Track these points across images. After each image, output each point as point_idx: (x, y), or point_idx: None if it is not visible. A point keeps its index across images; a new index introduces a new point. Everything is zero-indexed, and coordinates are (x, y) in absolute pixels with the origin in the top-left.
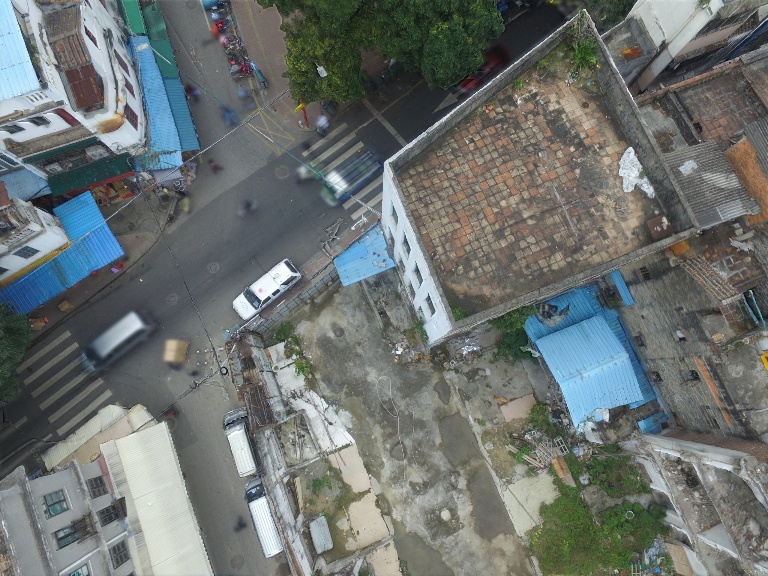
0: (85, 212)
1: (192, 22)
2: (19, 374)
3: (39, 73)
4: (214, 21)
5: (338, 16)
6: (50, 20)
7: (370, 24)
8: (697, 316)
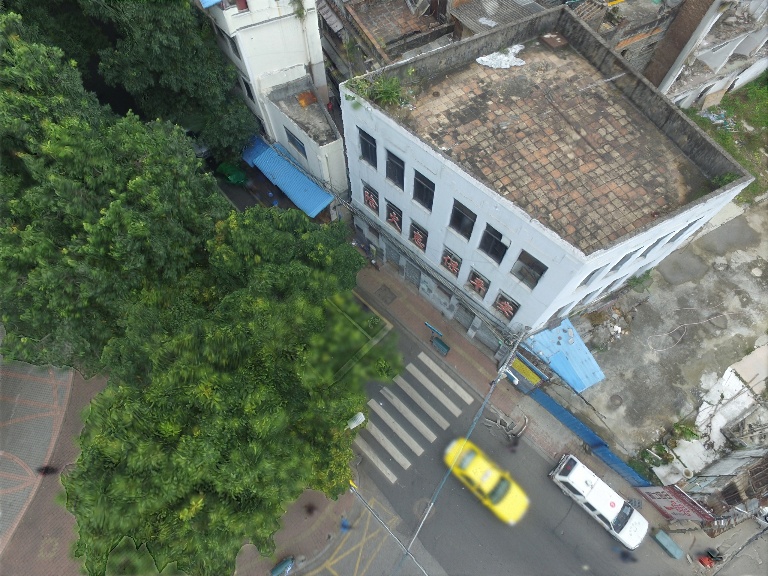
0: None
1: None
2: None
3: None
4: None
5: None
6: None
7: None
8: None
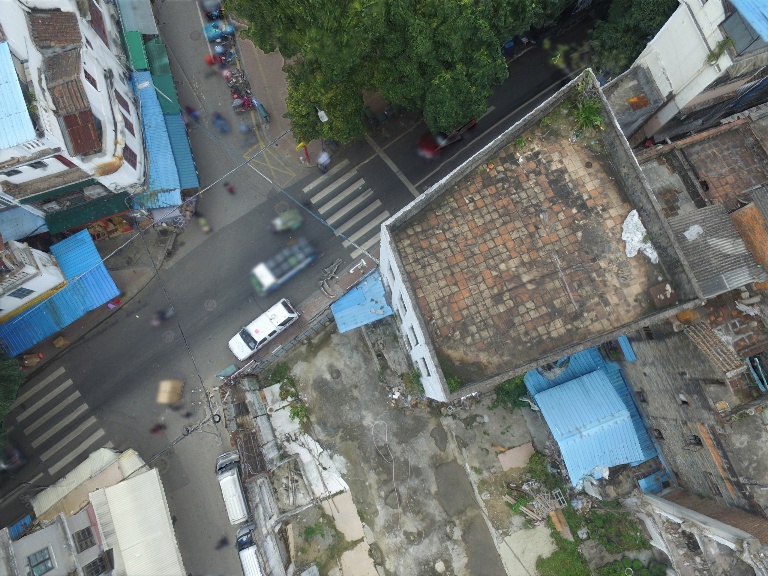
0: (82, 251)
1: (196, 54)
2: (12, 411)
3: (36, 121)
4: (218, 53)
5: (340, 63)
6: (50, 64)
7: (373, 67)
8: (700, 384)
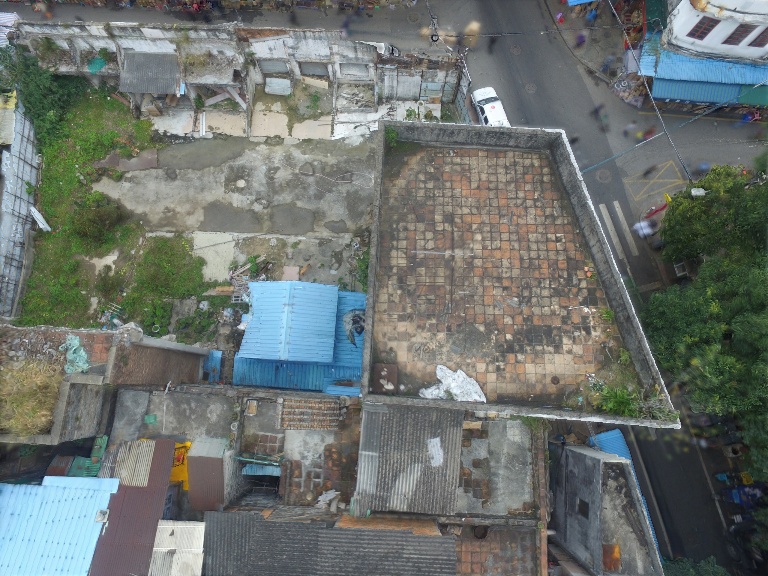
0: None
1: None
2: None
3: None
4: None
5: (760, 208)
6: None
7: None
8: None
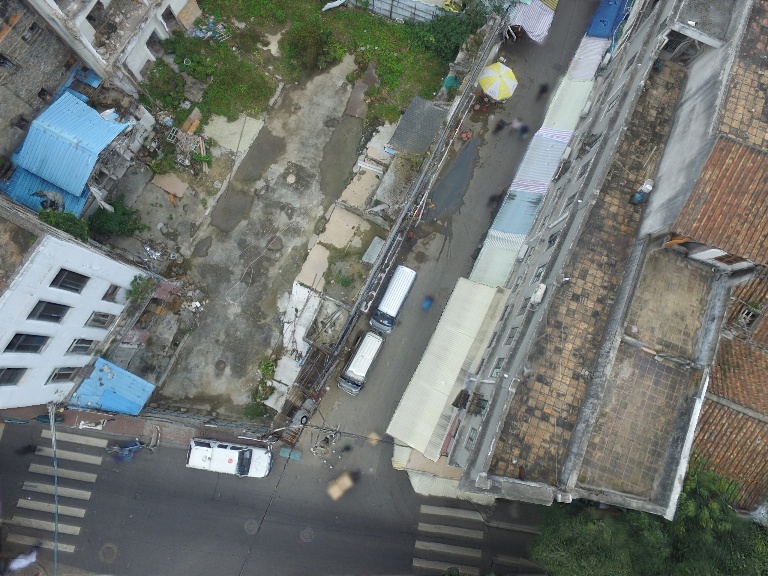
0: None
1: None
2: None
3: None
4: None
5: None
6: None
7: None
8: None
